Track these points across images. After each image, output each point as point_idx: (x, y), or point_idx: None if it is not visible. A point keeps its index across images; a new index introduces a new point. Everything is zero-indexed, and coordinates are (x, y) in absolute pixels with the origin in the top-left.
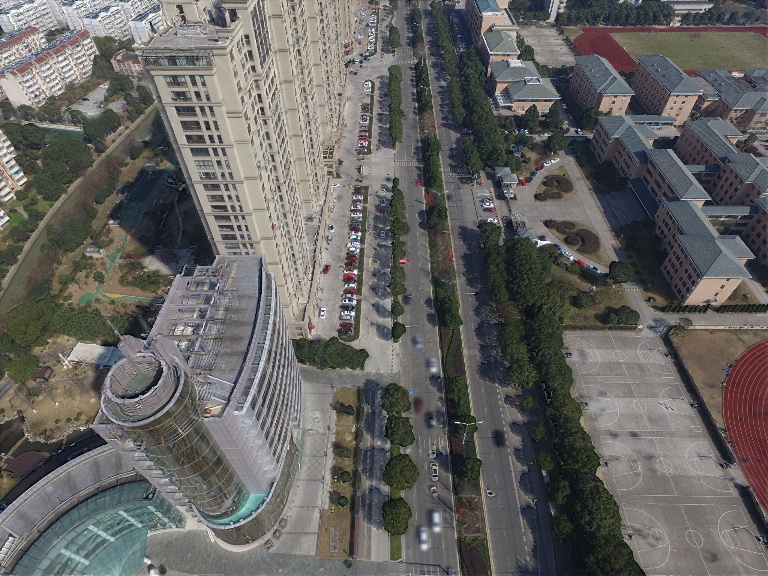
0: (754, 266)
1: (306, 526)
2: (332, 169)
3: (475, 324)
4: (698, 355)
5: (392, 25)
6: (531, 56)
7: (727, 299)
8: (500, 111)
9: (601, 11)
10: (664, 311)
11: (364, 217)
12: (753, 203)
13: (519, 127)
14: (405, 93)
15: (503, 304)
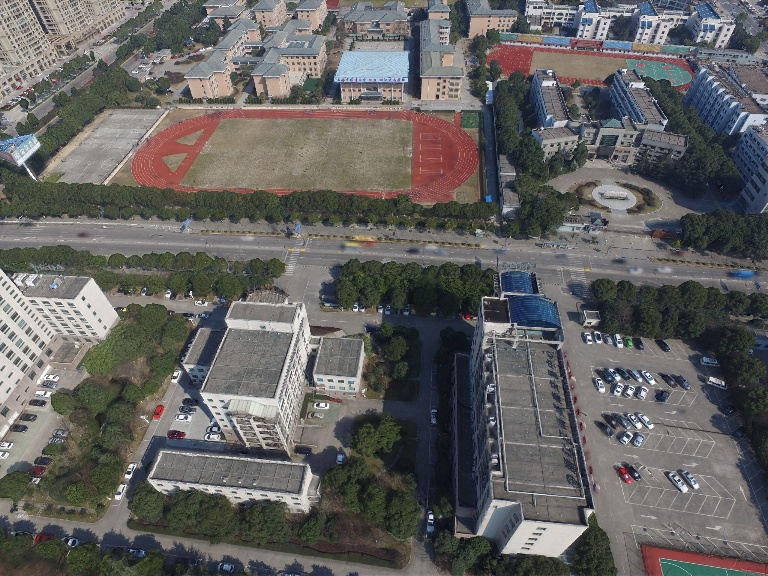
0: None
1: None
2: (62, 49)
3: None
4: (175, 116)
5: None
6: None
7: None
8: (204, 26)
9: None
10: (180, 103)
11: None
12: None
13: None
14: None
15: None
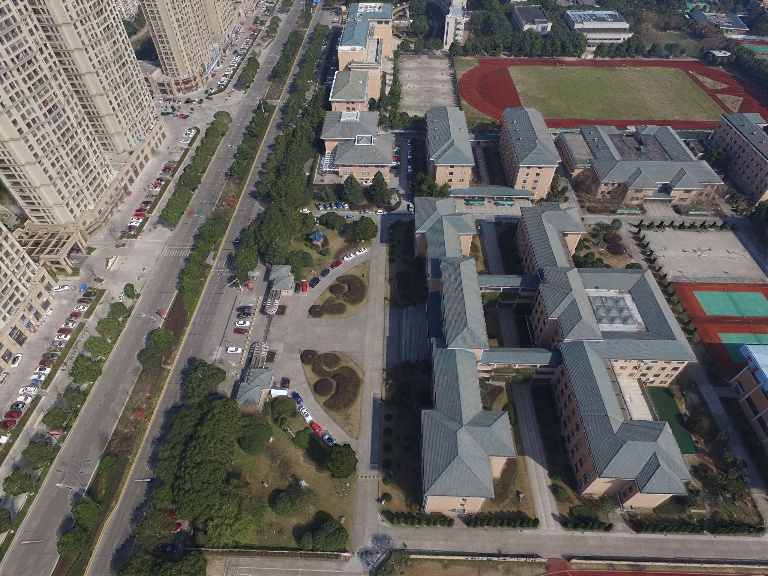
0: (546, 441)
1: None
2: (62, 266)
3: (120, 541)
4: None
5: (256, 54)
6: (396, 99)
7: (490, 500)
8: (325, 176)
9: (502, 40)
10: (393, 523)
11: (70, 341)
12: (559, 346)
13: (340, 199)
14: None
15: (143, 524)
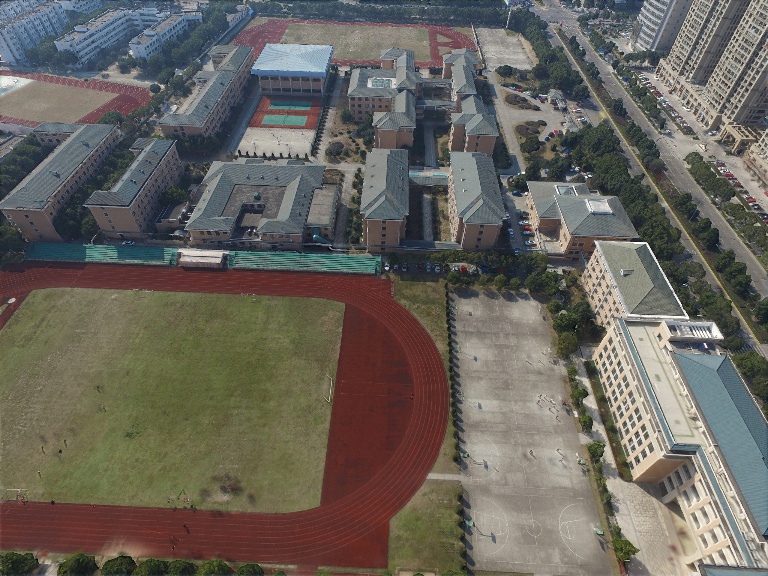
0: None
1: (619, 44)
2: None
3: None
4: None
5: None
6: None
7: None
8: None
9: None
10: None
11: (670, 114)
12: None
13: None
14: (740, 256)
15: (569, 63)
